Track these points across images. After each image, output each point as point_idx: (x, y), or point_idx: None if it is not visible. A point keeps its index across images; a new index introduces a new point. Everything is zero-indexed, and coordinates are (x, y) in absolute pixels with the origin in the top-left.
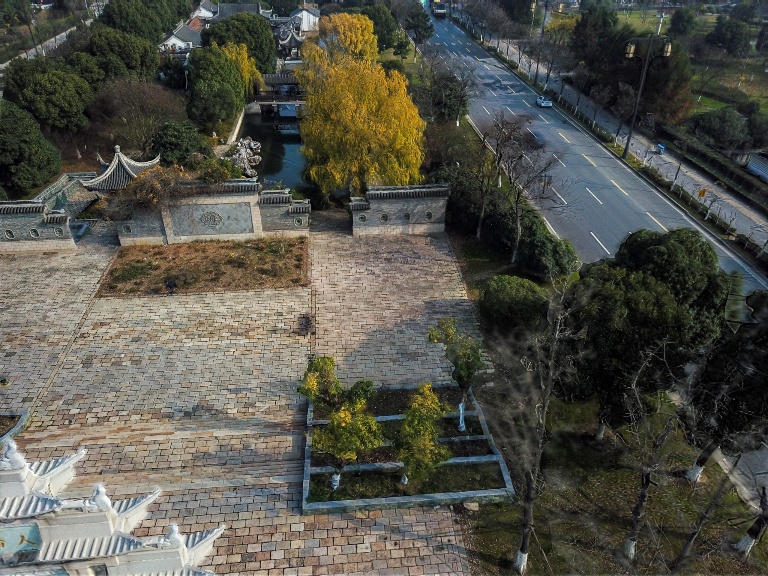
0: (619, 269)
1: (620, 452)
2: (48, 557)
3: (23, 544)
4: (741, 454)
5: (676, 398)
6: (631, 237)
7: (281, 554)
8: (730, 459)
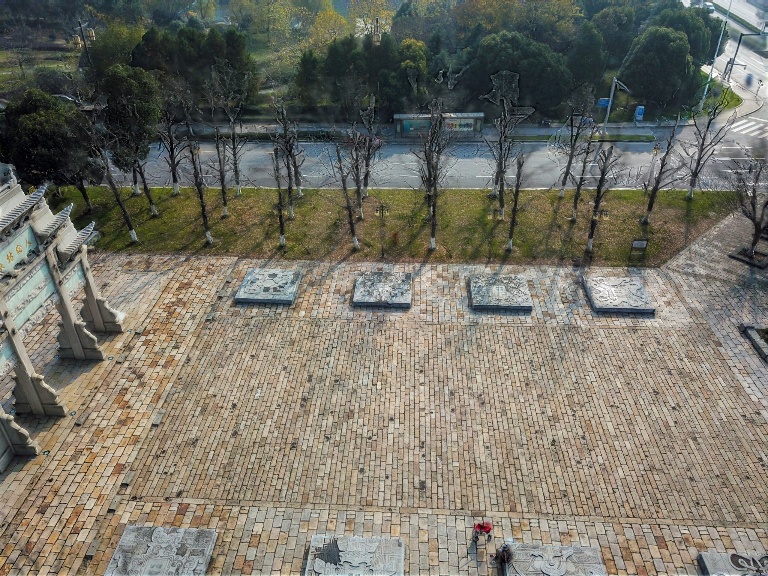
0: (32, 113)
1: (106, 206)
2: (49, 231)
3: (27, 246)
4: (148, 154)
5: (107, 157)
6: (8, 109)
7: (54, 310)
8: (139, 182)
